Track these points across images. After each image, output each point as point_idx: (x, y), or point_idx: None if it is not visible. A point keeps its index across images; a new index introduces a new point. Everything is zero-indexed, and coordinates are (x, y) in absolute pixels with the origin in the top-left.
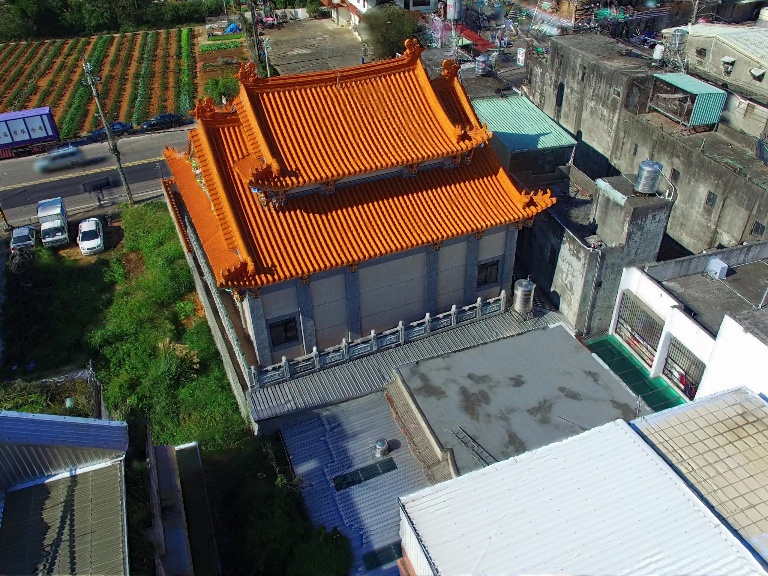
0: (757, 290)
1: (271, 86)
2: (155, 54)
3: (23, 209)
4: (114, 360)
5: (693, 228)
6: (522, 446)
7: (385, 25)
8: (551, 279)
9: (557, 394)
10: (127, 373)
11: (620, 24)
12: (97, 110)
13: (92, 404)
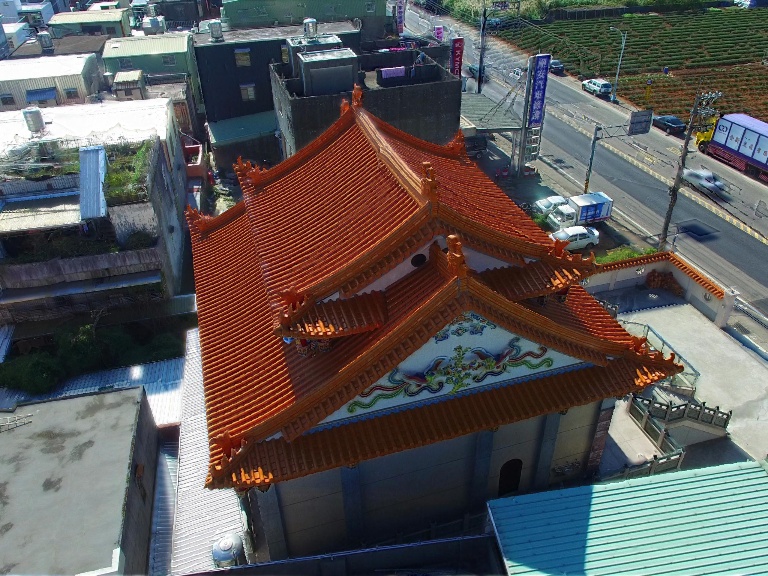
0: None
1: None
2: None
3: (626, 198)
4: None
5: None
6: None
7: None
8: None
9: (6, 518)
10: None
11: None
12: None
13: None
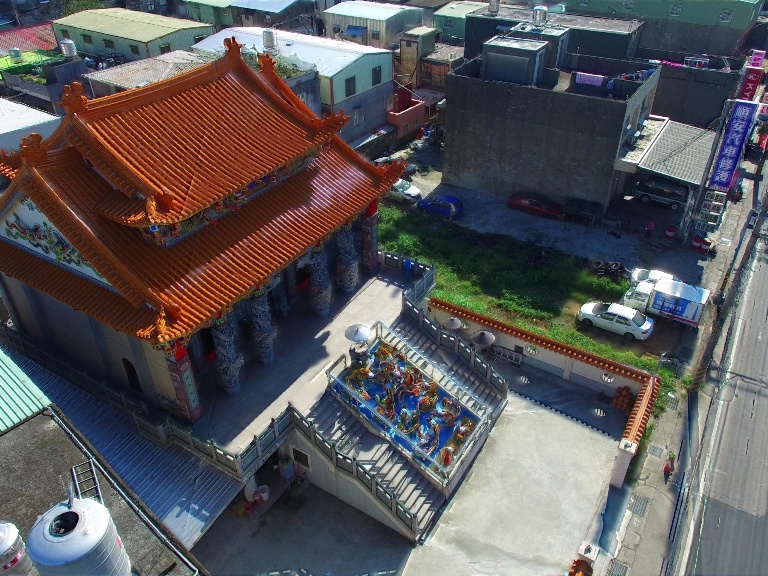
0: None
1: None
2: None
3: None
4: None
5: None
6: None
7: None
8: None
9: None
10: None
11: None
12: None
13: None
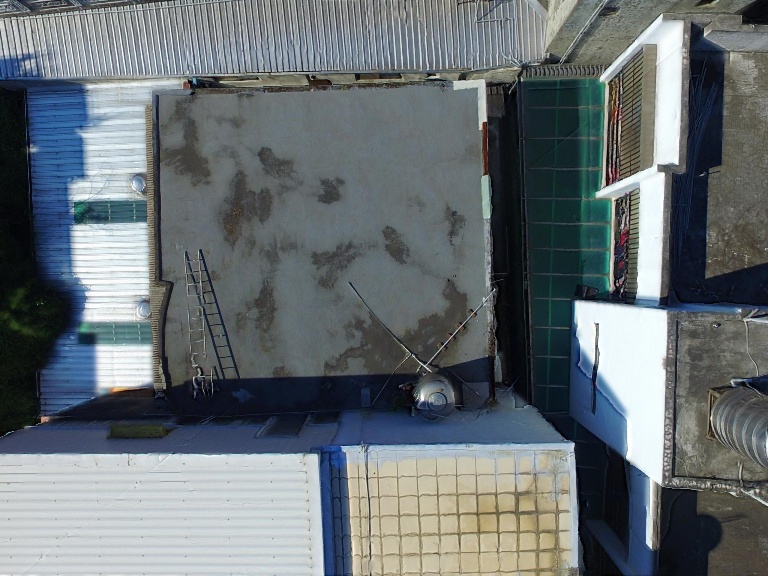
0: None
1: None
2: None
3: None
4: None
5: None
6: (270, 314)
7: None
8: None
9: (375, 239)
10: None
11: None
12: None
13: None
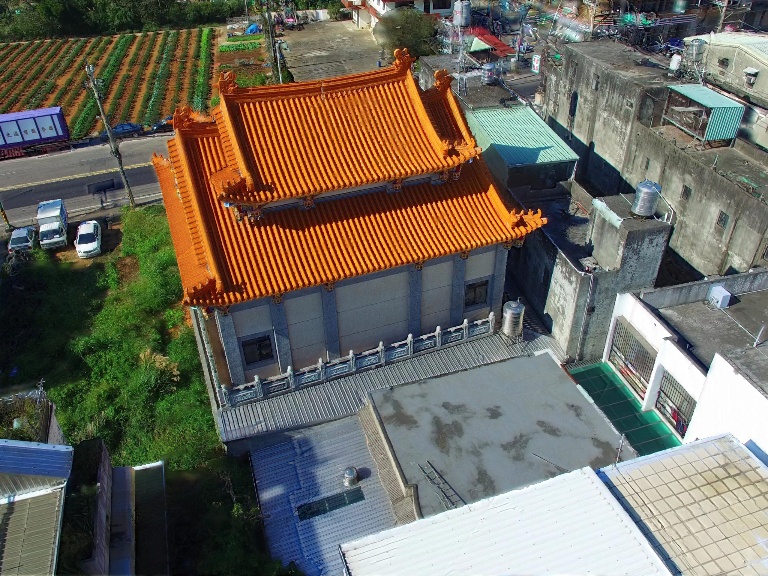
0: (761, 321)
1: (252, 96)
2: (174, 54)
3: (27, 209)
4: (95, 369)
5: (704, 248)
6: (491, 485)
7: (402, 28)
8: (544, 301)
9: (535, 428)
10: (107, 383)
11: (640, 31)
12: (110, 110)
13: (37, 427)
